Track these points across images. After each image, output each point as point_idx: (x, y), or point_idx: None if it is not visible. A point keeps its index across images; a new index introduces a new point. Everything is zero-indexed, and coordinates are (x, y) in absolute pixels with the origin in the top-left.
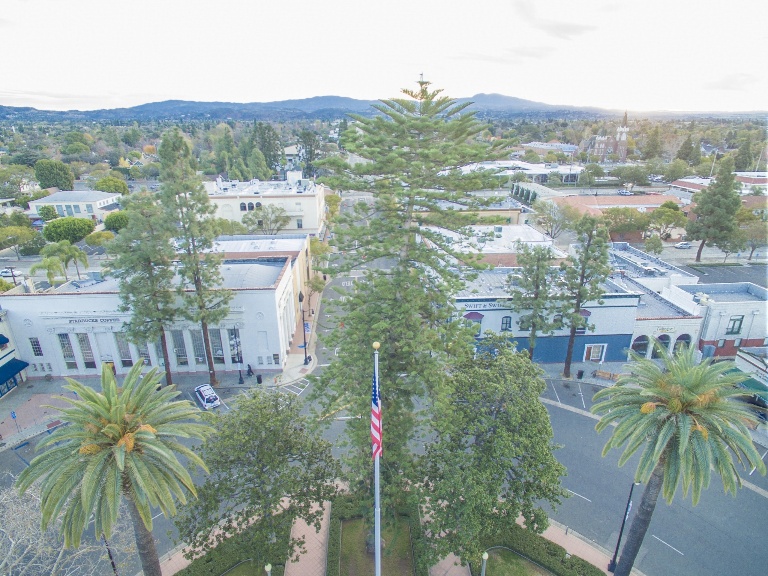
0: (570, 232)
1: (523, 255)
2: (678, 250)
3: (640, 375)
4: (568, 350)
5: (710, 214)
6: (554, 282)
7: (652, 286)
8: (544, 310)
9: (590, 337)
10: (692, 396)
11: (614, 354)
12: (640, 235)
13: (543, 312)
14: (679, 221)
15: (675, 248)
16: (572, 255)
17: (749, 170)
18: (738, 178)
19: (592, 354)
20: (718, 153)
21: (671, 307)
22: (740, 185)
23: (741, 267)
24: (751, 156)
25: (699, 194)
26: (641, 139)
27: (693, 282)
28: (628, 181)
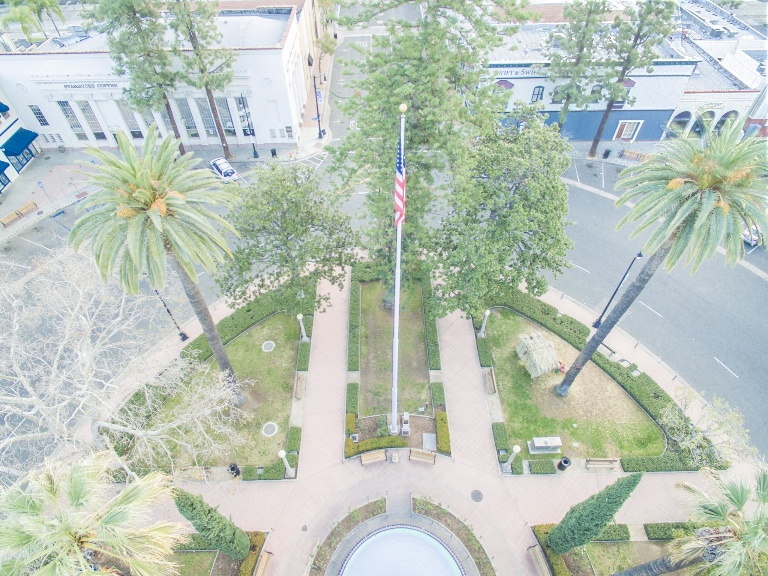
0: None
1: (572, 6)
2: (760, 3)
3: (669, 156)
4: (600, 127)
5: None
6: (602, 43)
7: (714, 51)
8: (583, 79)
9: (627, 112)
10: (717, 179)
11: (648, 132)
12: None
13: (582, 81)
14: None
15: (757, 0)
16: None
17: None
18: None
19: (624, 132)
20: None
21: (728, 78)
22: None
23: None
24: None
25: None
26: None
27: (765, 46)
28: None
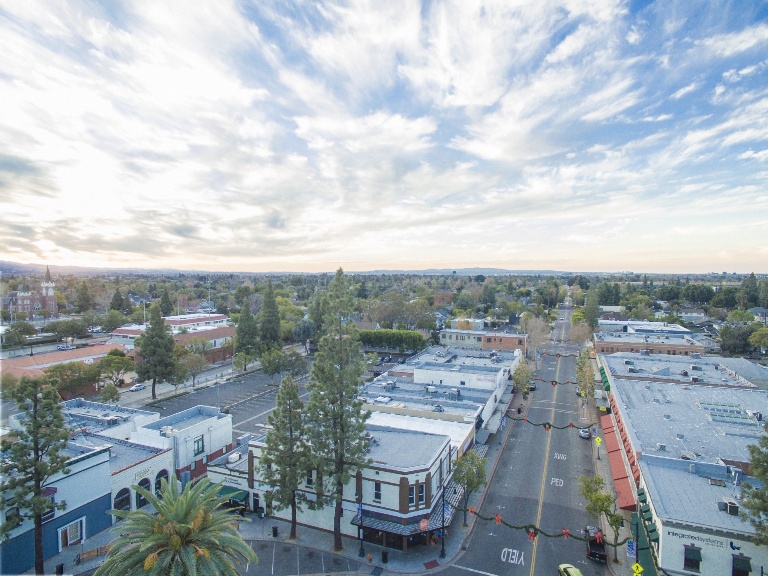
0: (6, 402)
1: None
2: (134, 393)
3: (130, 533)
4: (35, 548)
5: (153, 355)
6: None
7: (119, 435)
8: None
9: (62, 518)
10: (183, 528)
11: (96, 524)
12: (93, 387)
13: None
14: (128, 366)
15: (131, 392)
16: (16, 428)
17: (173, 314)
18: (167, 322)
19: (69, 537)
20: (146, 302)
21: (142, 449)
22: (170, 327)
23: (189, 394)
24: (172, 303)
25: (140, 339)
26: (70, 293)
27: (156, 419)
28: (66, 335)
